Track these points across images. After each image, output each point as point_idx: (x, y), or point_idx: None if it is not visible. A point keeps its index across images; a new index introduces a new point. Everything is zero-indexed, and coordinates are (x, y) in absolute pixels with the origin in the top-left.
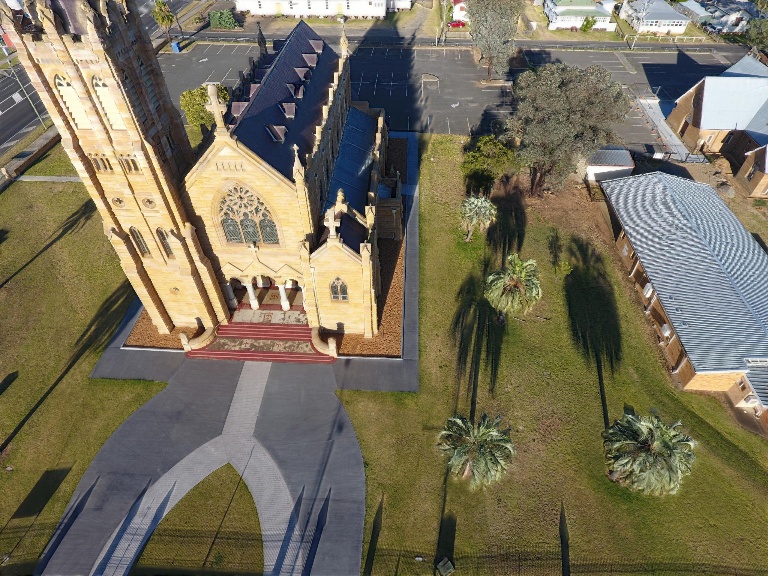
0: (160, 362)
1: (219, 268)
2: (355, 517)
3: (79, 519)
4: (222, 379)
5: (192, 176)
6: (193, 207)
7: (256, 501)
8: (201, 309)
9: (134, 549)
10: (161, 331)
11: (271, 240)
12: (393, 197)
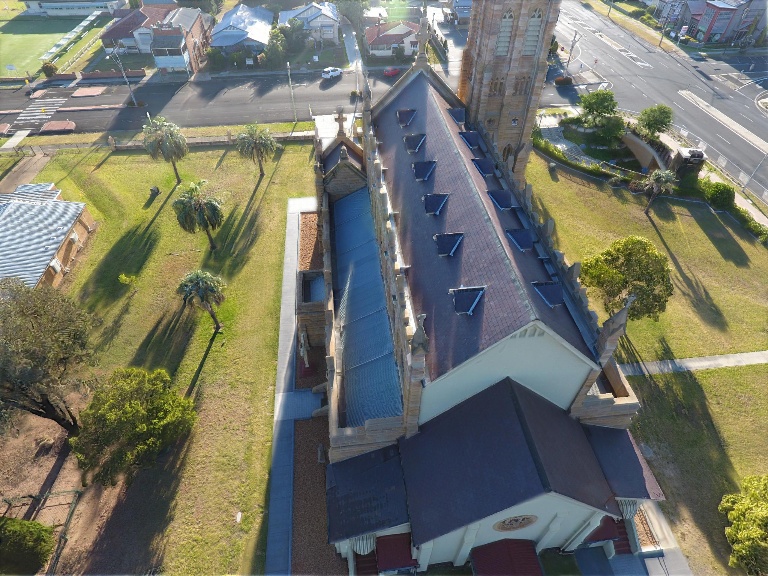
0: None
1: None
2: None
3: None
4: None
5: None
6: None
7: None
8: None
9: None
10: None
11: None
12: (308, 296)
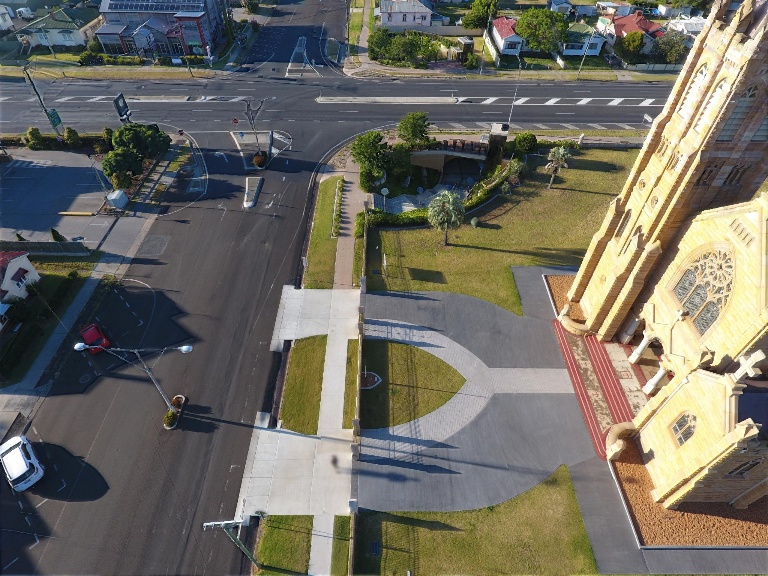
0: (540, 304)
1: (645, 301)
2: (439, 501)
3: (412, 301)
4: (541, 354)
5: (708, 213)
6: (683, 238)
7: (440, 409)
8: (597, 308)
9: (397, 337)
10: (569, 294)
11: (700, 326)
12: None
